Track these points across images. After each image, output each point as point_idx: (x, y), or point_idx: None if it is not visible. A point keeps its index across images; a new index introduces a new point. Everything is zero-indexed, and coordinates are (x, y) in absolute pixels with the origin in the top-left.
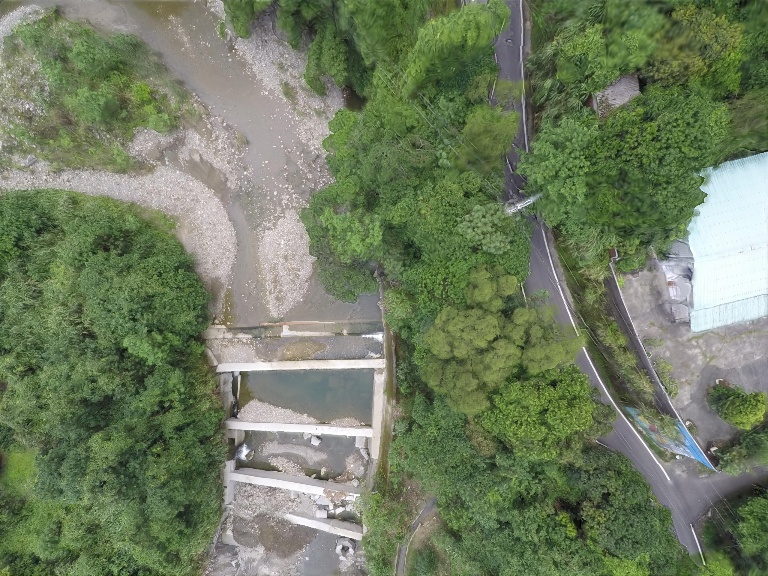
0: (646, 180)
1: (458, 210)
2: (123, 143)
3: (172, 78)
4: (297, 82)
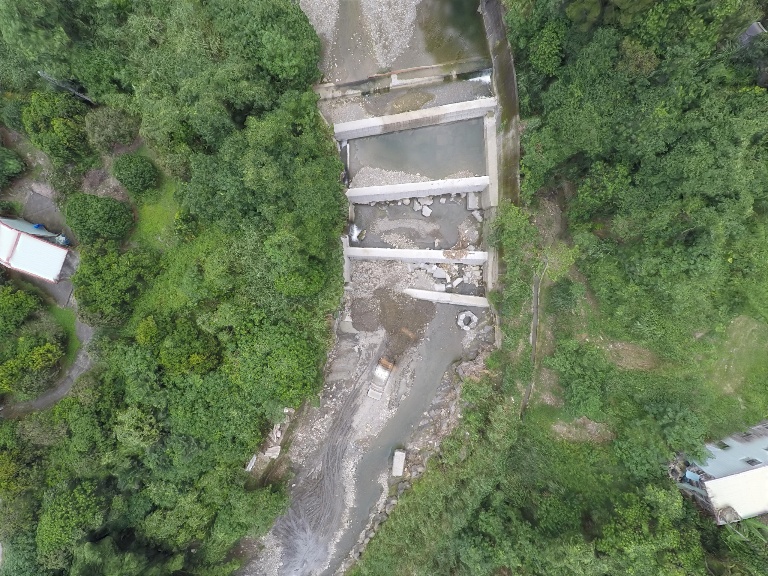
0: None
1: None
2: None
3: None
4: None
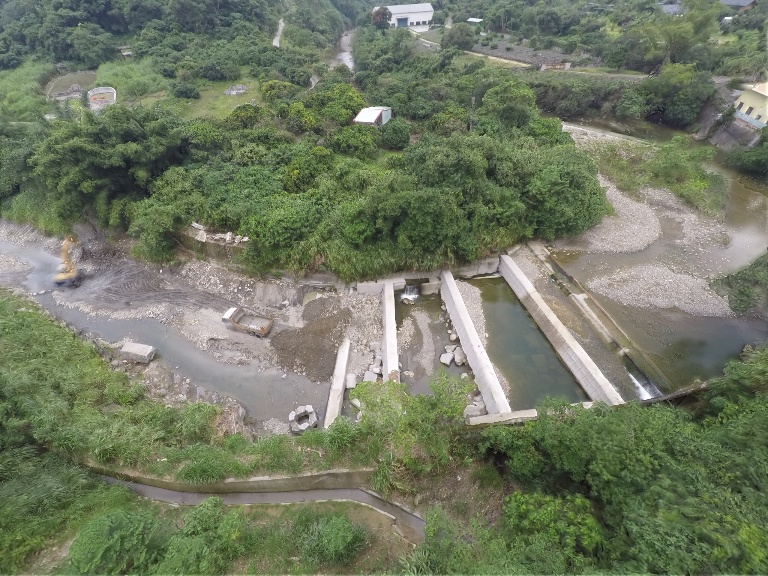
0: None
1: None
2: (648, 186)
3: None
4: None
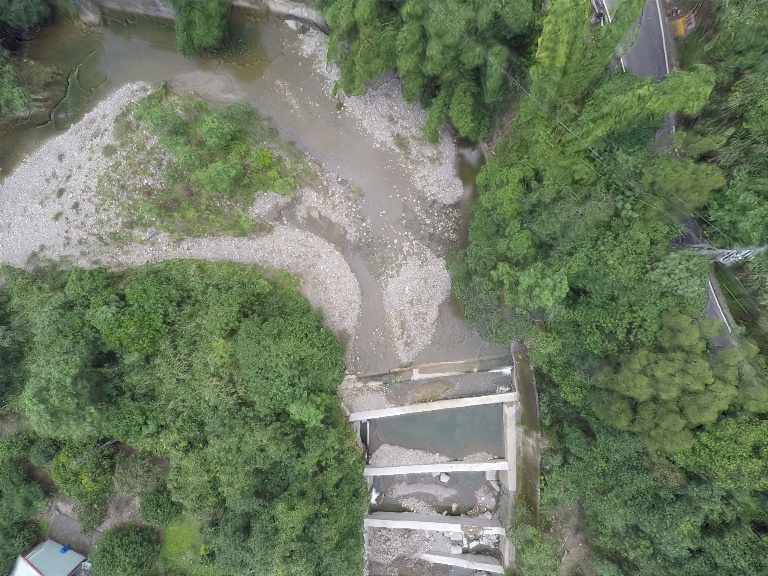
0: None
1: (645, 257)
2: (244, 208)
3: (285, 140)
4: (408, 132)
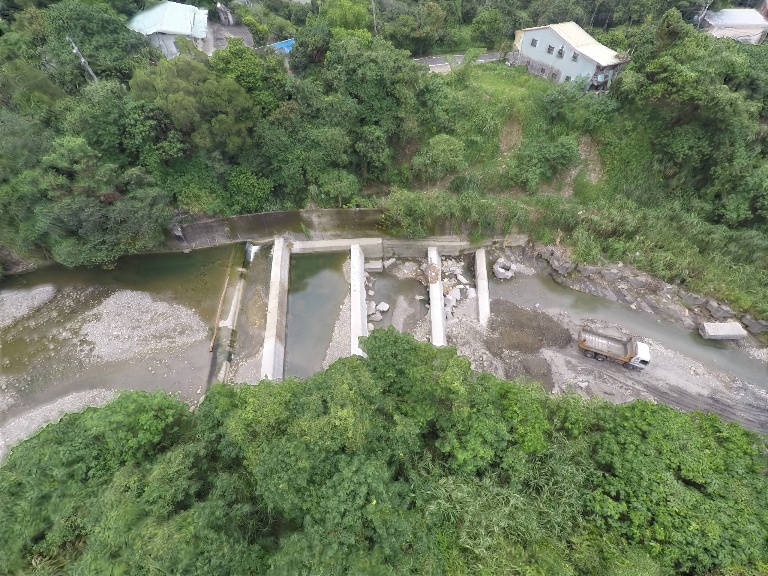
0: (79, 11)
1: None
2: None
3: None
4: None
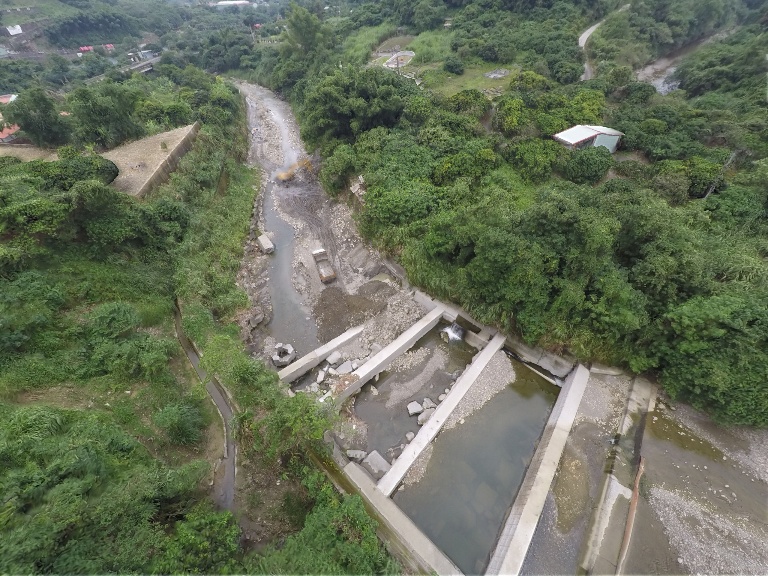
0: None
1: None
2: None
3: None
4: None
